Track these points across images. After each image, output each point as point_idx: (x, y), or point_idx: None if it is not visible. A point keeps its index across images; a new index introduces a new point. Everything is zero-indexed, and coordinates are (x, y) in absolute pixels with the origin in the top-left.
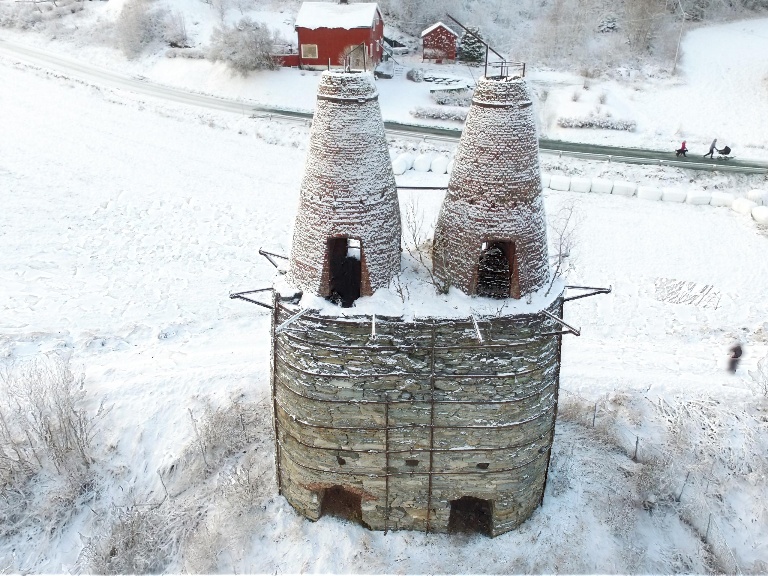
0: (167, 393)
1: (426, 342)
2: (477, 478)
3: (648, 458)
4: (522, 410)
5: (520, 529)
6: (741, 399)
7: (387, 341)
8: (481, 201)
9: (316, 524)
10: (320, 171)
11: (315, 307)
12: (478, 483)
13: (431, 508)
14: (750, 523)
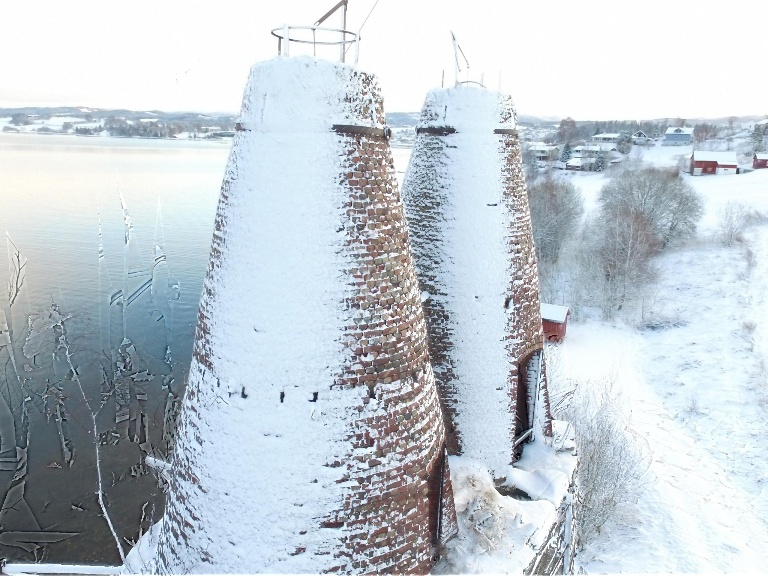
0: None
1: None
2: None
3: None
4: None
5: None
6: None
7: None
8: None
9: None
10: None
11: None
12: None
13: None
14: None
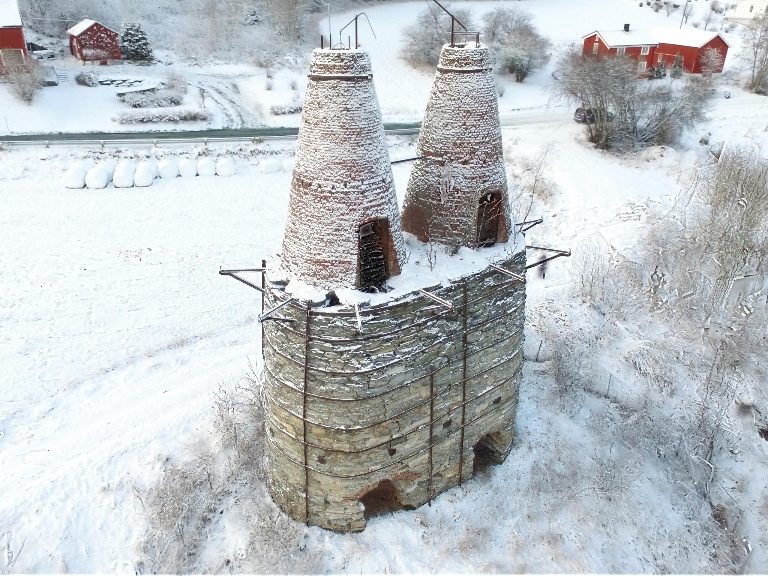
0: (61, 501)
1: (459, 302)
2: (493, 414)
3: (549, 355)
4: (519, 339)
5: (517, 446)
6: (562, 293)
7: (431, 312)
8: (474, 160)
9: (367, 532)
10: (341, 156)
11: (365, 300)
12: (494, 418)
13: (462, 460)
14: (617, 374)
